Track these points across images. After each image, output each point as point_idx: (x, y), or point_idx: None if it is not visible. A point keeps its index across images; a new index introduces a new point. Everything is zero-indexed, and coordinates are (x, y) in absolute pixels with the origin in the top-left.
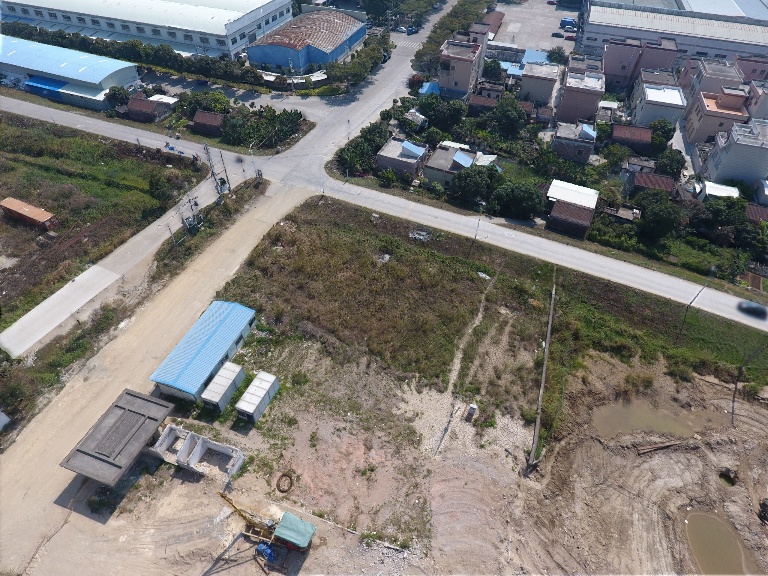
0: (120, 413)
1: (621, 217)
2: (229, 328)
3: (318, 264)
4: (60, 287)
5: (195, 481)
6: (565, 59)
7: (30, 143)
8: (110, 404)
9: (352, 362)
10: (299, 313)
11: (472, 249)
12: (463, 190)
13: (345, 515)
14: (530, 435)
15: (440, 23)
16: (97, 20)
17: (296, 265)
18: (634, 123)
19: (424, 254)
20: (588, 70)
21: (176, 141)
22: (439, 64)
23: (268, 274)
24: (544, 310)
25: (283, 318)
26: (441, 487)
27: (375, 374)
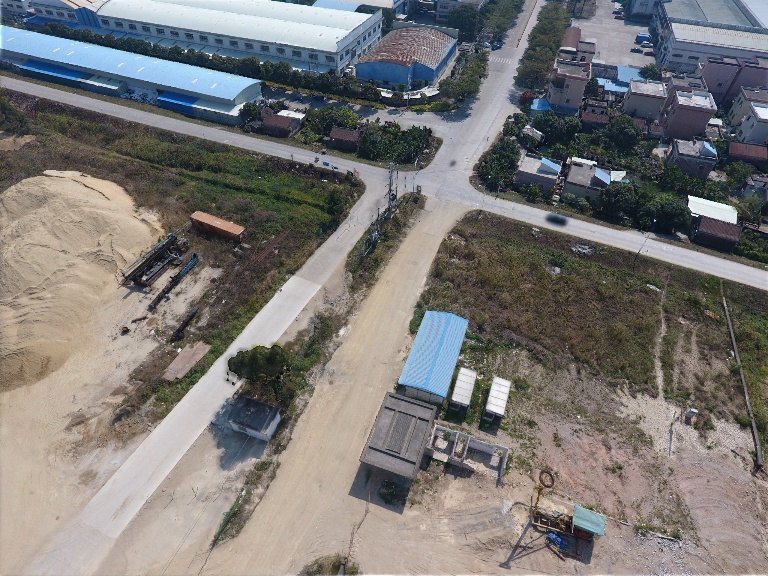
0: (392, 414)
1: (765, 232)
2: (453, 336)
3: (503, 276)
4: (271, 296)
5: (466, 476)
6: (657, 76)
7: (188, 158)
8: (361, 406)
9: (563, 369)
10: (499, 322)
11: (636, 262)
12: (612, 206)
13: (612, 508)
14: (749, 438)
15: (537, 41)
16: (206, 36)
17: (482, 277)
18: (741, 140)
19: (593, 267)
20: (692, 88)
21: (323, 156)
22: (550, 82)
23: (455, 285)
24: (722, 321)
25: (485, 327)
26: (687, 484)
27: (588, 380)
